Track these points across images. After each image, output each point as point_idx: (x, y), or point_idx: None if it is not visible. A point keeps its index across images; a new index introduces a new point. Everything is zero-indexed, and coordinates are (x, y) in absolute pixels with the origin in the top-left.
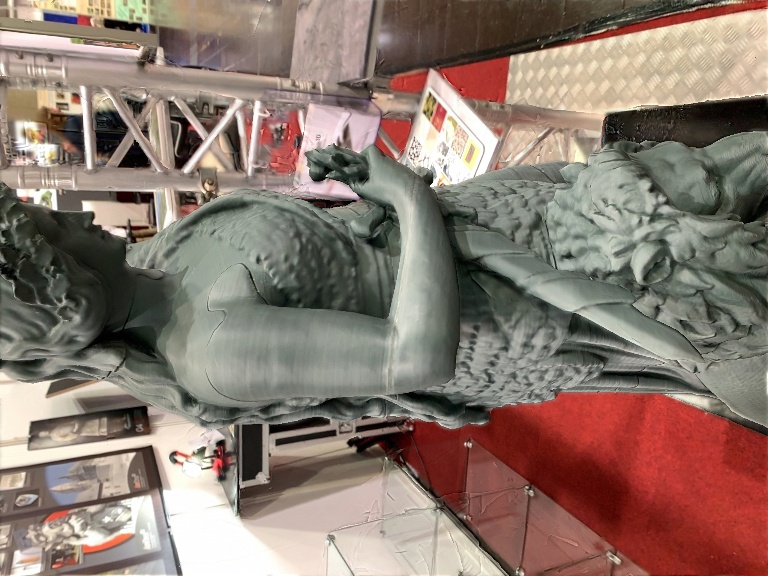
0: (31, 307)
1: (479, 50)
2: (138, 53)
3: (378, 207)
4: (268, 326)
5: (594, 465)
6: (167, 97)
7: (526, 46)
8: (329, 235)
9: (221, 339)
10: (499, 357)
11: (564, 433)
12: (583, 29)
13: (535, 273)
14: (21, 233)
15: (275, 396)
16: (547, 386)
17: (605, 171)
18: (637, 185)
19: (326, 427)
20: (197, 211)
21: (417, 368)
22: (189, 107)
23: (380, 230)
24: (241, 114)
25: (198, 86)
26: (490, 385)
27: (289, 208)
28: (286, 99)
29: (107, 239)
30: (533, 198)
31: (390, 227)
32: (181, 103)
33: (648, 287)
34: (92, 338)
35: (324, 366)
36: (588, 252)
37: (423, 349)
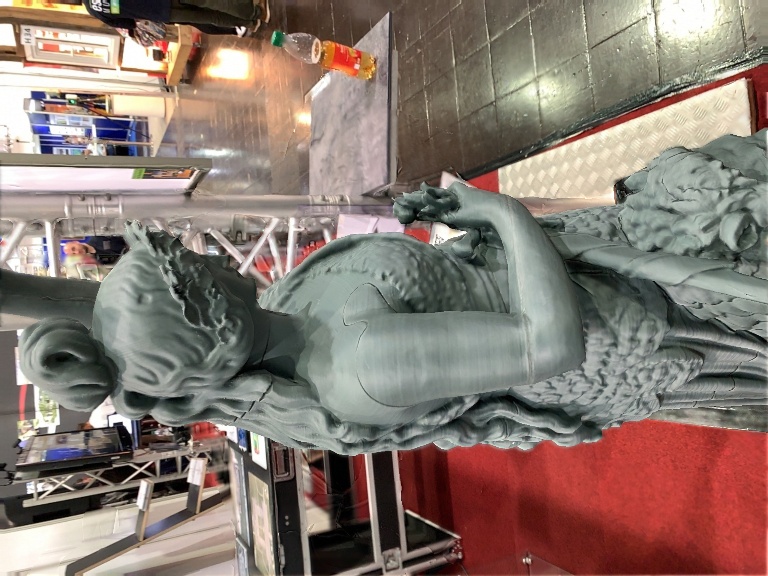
0: (194, 330)
1: (466, 170)
2: (188, 183)
3: (473, 230)
4: (409, 326)
5: (671, 553)
6: (203, 230)
7: (511, 158)
8: (437, 255)
9: (369, 342)
10: (610, 355)
11: (630, 524)
12: (561, 135)
13: (636, 257)
14: (184, 261)
15: (423, 395)
16: (655, 388)
17: (674, 163)
18: (708, 166)
19: (371, 566)
20: (306, 259)
21: (554, 348)
22: (224, 236)
23: (476, 253)
24: (272, 237)
25: (238, 210)
26: (603, 389)
27: (397, 237)
28: (318, 213)
29: (242, 278)
30: (603, 213)
31: (485, 249)
32: (217, 233)
33: (740, 257)
34: (243, 363)
35: (468, 356)
36: (674, 239)
37: (556, 329)
